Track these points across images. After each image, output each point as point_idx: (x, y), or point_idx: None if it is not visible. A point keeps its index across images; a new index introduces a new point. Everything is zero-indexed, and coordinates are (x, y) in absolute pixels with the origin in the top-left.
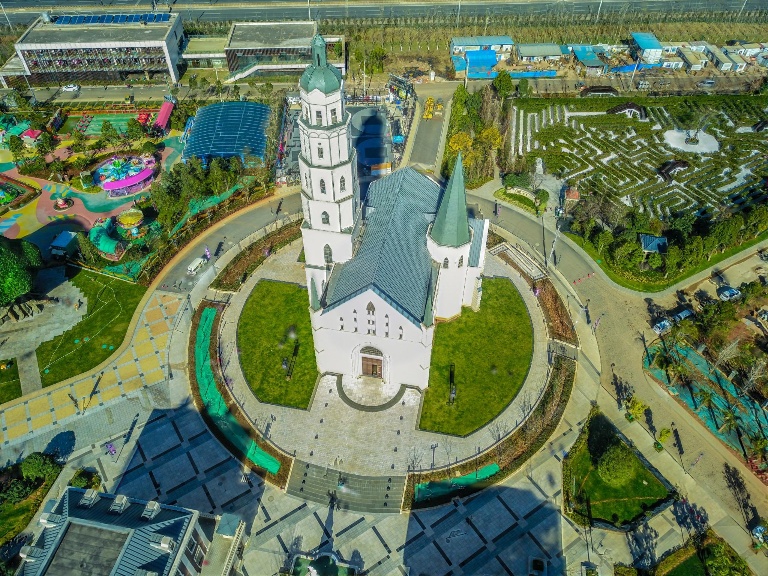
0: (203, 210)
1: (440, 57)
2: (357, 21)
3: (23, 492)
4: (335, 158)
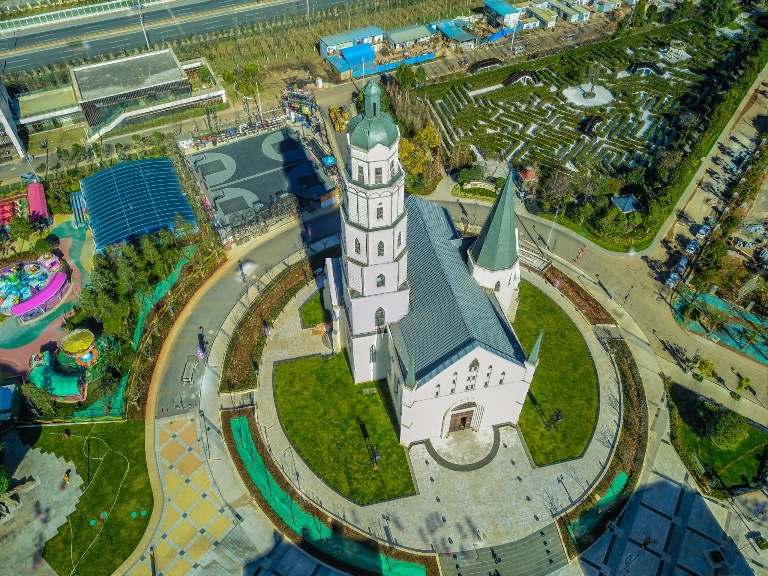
0: (156, 303)
1: (313, 61)
2: (200, 38)
3: None
4: (394, 214)
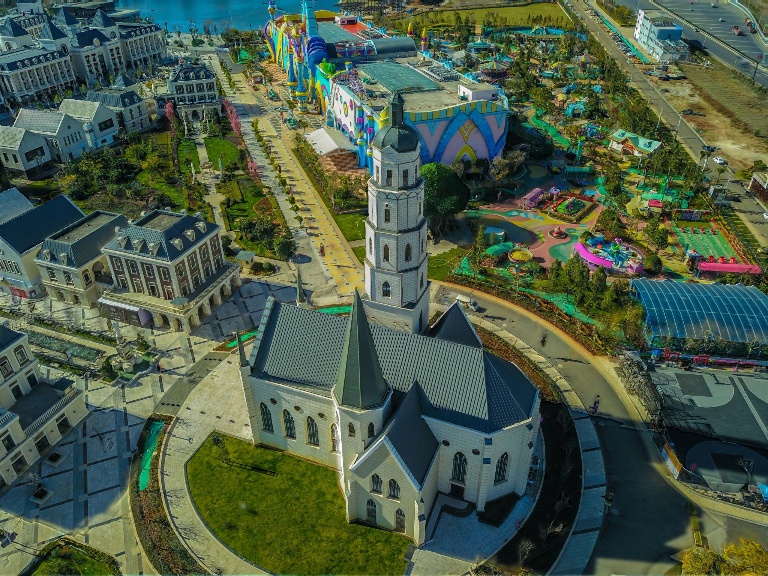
0: (554, 304)
1: None
2: None
3: (266, 244)
4: None
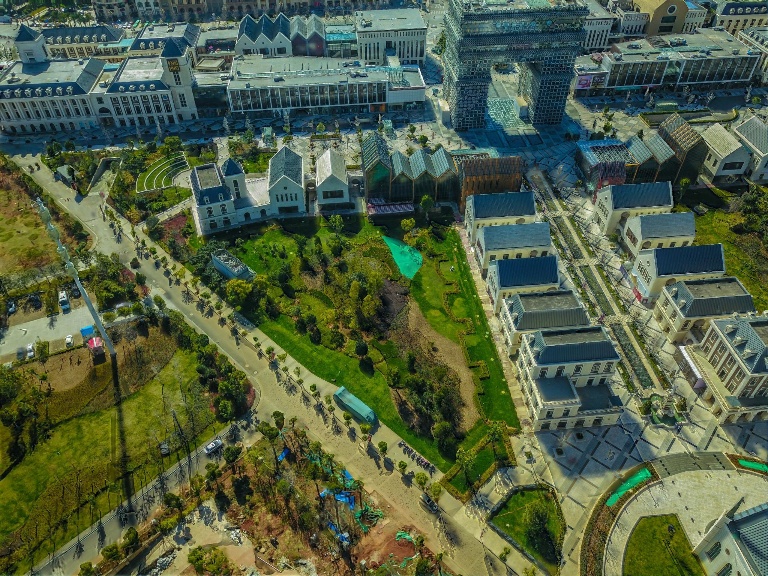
0: None
1: None
2: None
3: None
4: None
